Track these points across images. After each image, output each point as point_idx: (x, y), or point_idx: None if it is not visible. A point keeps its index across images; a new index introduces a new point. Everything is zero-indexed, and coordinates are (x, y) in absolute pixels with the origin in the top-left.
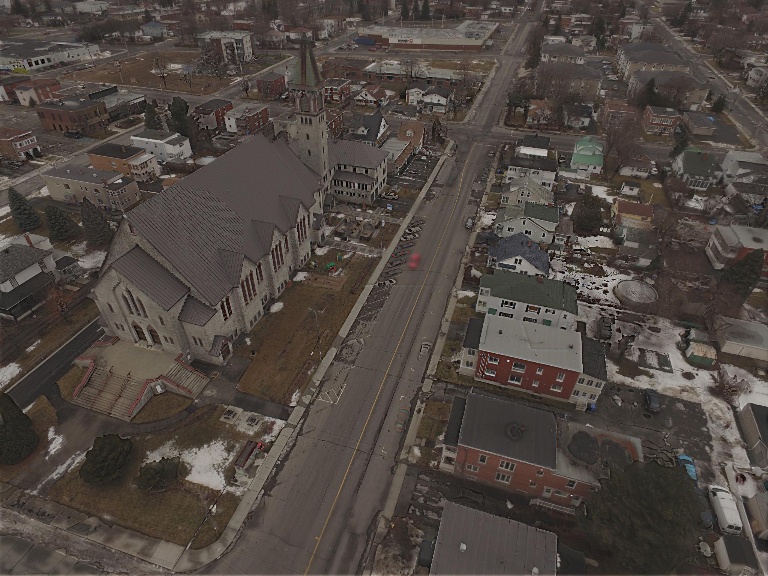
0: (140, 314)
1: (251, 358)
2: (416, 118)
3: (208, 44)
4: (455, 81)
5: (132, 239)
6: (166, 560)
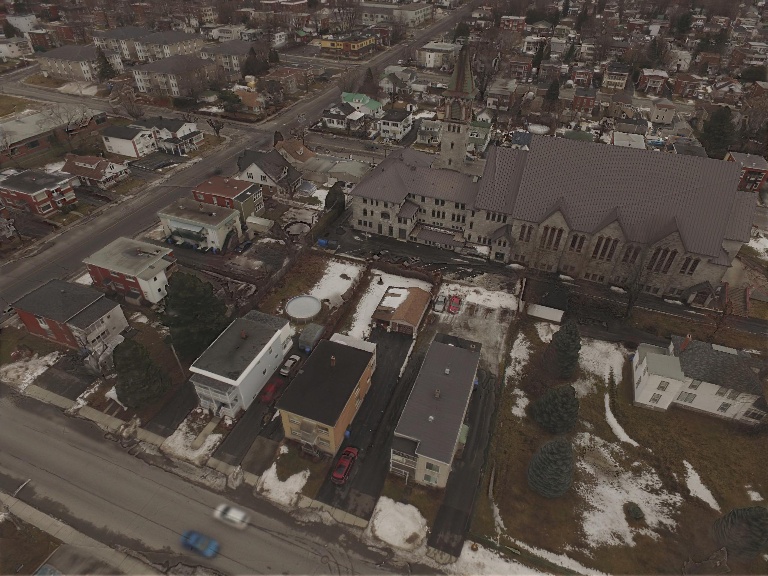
0: None
1: None
2: (197, 158)
3: None
4: (100, 117)
5: None
6: None
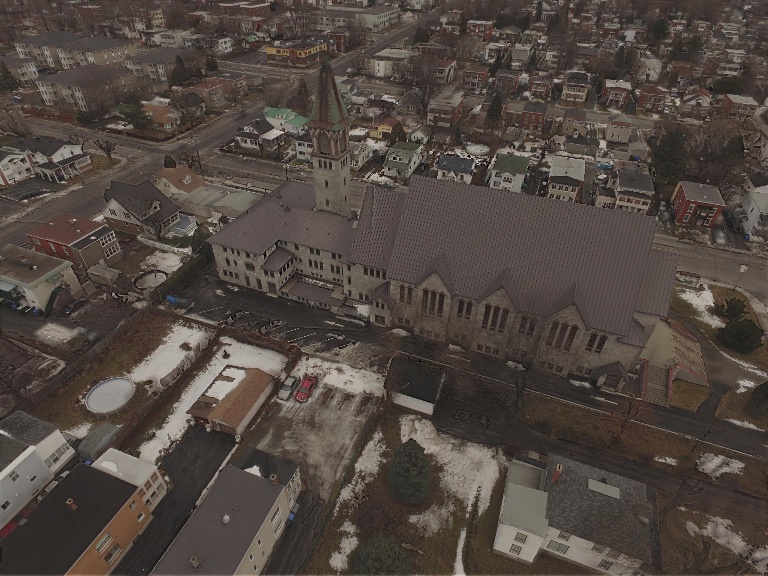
0: None
1: None
2: (76, 185)
3: None
4: None
5: None
6: (761, 307)
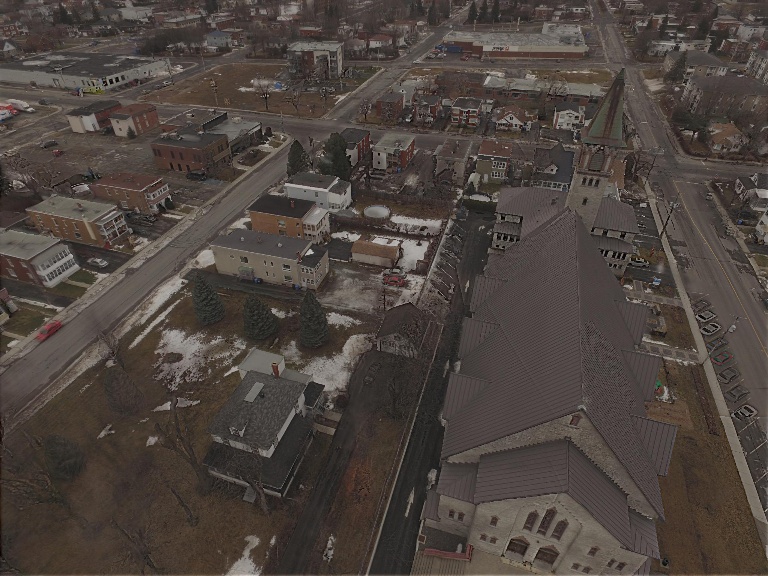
0: (544, 532)
1: (666, 572)
2: (577, 146)
3: (298, 57)
4: (596, 98)
5: (563, 431)
6: None
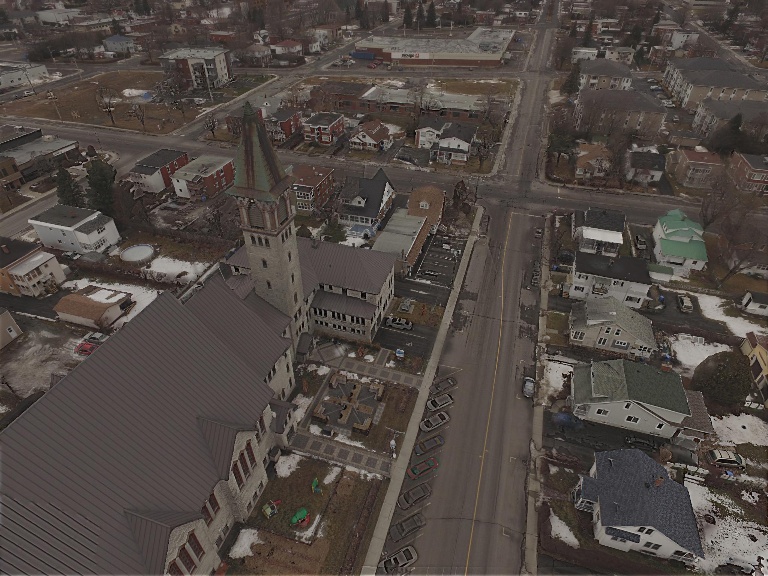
0: None
1: None
2: (429, 169)
3: (173, 65)
4: (475, 113)
5: None
6: None
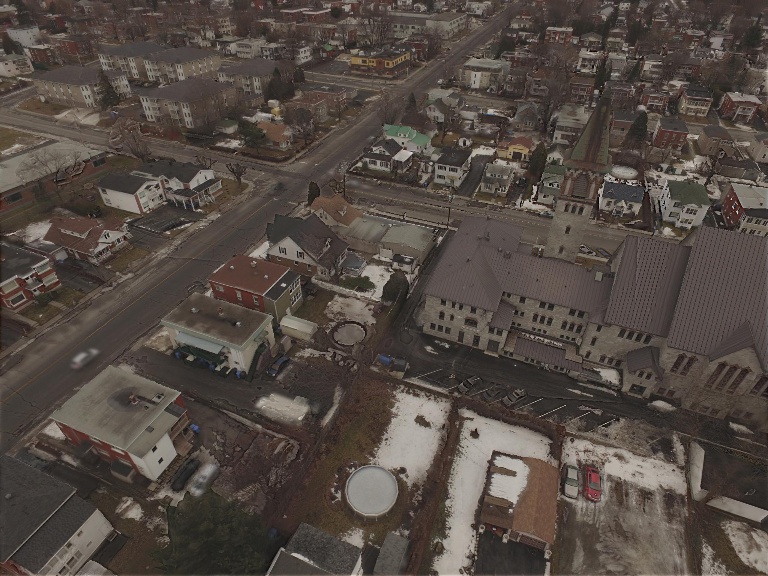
0: None
1: None
2: (214, 214)
3: None
4: (99, 157)
5: None
6: None
